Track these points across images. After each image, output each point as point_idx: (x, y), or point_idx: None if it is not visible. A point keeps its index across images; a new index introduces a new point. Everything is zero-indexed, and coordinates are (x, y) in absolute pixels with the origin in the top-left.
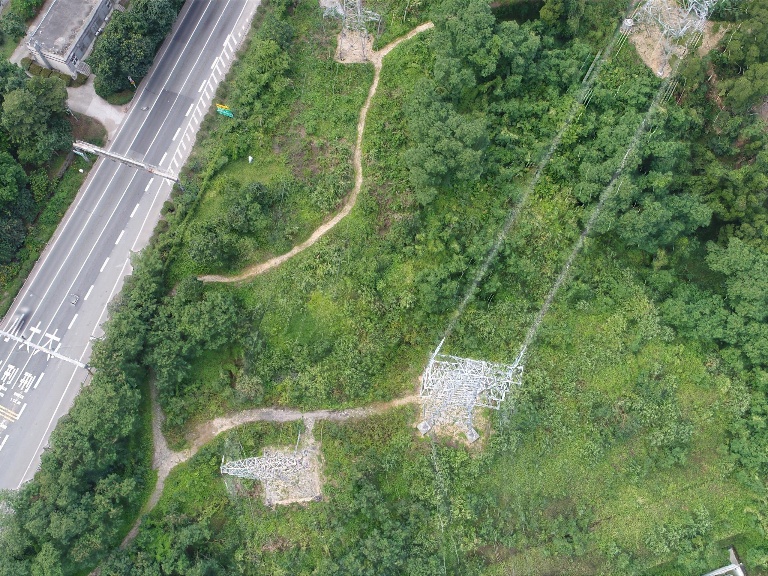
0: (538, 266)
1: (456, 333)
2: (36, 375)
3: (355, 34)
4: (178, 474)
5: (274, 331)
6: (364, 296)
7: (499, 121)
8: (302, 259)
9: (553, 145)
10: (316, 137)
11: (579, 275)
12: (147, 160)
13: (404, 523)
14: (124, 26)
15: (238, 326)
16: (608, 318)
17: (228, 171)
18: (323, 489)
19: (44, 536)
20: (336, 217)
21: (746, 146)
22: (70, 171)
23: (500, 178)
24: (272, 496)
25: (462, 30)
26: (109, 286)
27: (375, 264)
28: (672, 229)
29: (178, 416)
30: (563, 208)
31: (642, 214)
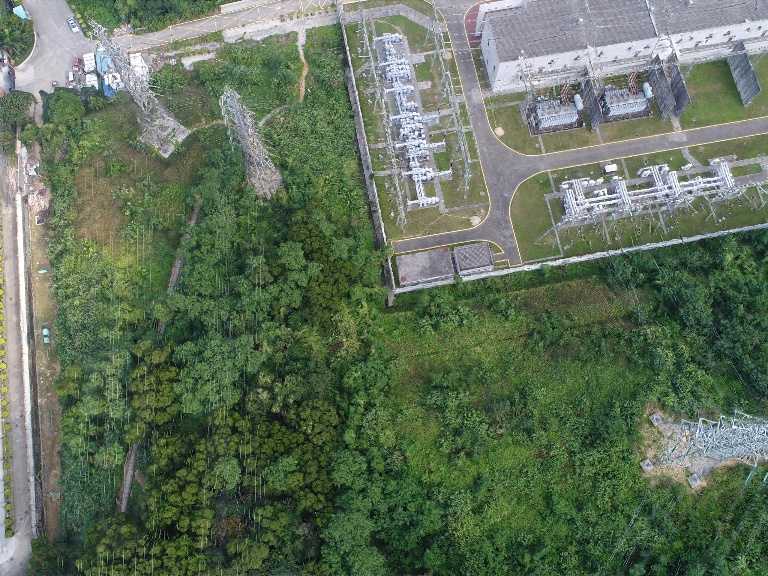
0: None
1: None
2: None
3: None
4: None
5: None
6: None
7: None
8: None
9: None
10: None
11: (530, 573)
12: None
13: (717, 354)
14: None
15: None
16: None
17: None
18: None
19: None
20: None
21: None
22: None
23: None
24: None
25: None
26: None
27: None
28: None
29: None
30: None
31: None
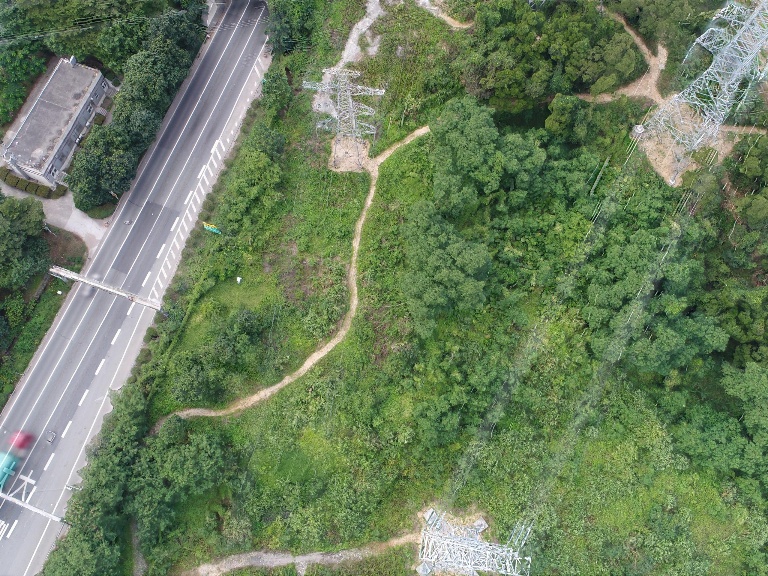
0: (544, 395)
1: (457, 465)
2: (9, 523)
3: (350, 139)
4: None
5: (264, 470)
6: (359, 434)
7: (502, 236)
8: (293, 392)
9: (559, 263)
10: (309, 254)
11: (587, 400)
12: (129, 280)
13: None
14: (104, 141)
15: (225, 469)
16: (618, 446)
17: (215, 293)
18: None
19: None
20: (330, 343)
21: (763, 261)
22: (48, 293)
23: (504, 302)
24: None
25: (463, 146)
26: (88, 422)
27: (371, 400)
28: (686, 354)
29: (161, 565)
30: (570, 330)
31: (655, 343)
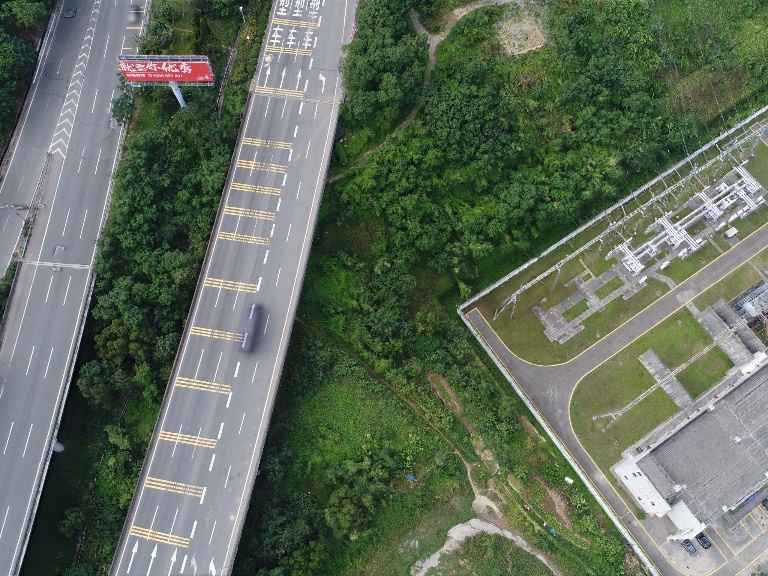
0: None
1: None
2: None
3: None
4: (443, 46)
5: None
6: None
7: None
8: None
9: None
10: None
11: None
12: None
13: None
14: None
15: None
16: None
17: None
18: (549, 35)
19: (383, 67)
20: None
21: None
22: None
23: None
24: (513, 50)
25: None
26: None
27: None
28: None
29: (430, 8)
30: None
31: None
